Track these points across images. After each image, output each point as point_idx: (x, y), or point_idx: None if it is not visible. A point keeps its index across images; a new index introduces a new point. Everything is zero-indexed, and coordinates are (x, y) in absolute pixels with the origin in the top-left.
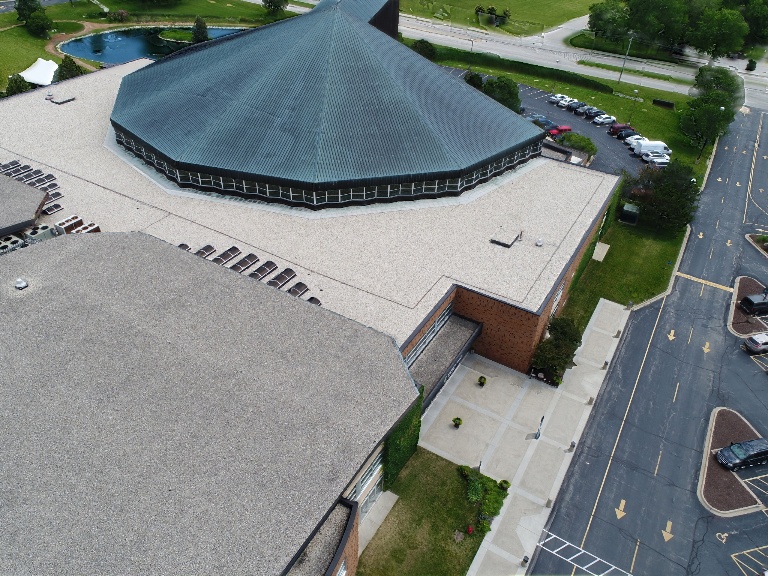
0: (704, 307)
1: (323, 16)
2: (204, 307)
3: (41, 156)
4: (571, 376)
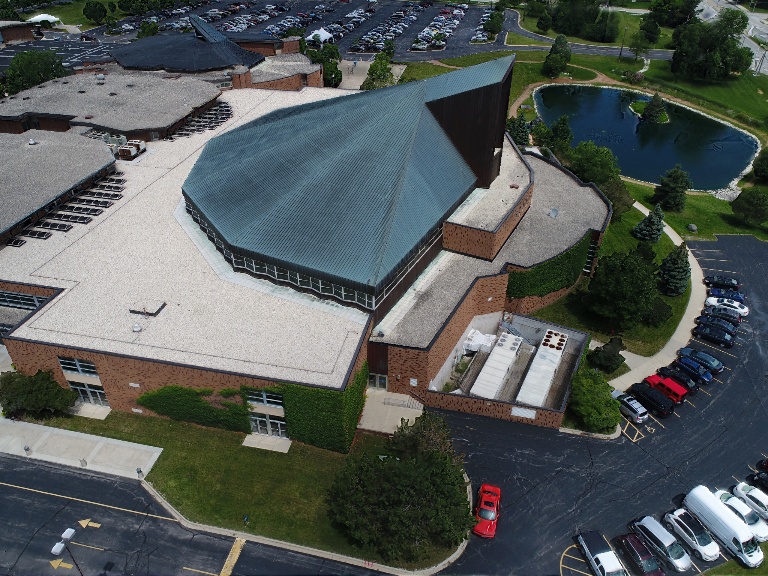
0: (154, 569)
1: (406, 84)
2: (6, 190)
3: (247, 119)
4: (20, 427)
